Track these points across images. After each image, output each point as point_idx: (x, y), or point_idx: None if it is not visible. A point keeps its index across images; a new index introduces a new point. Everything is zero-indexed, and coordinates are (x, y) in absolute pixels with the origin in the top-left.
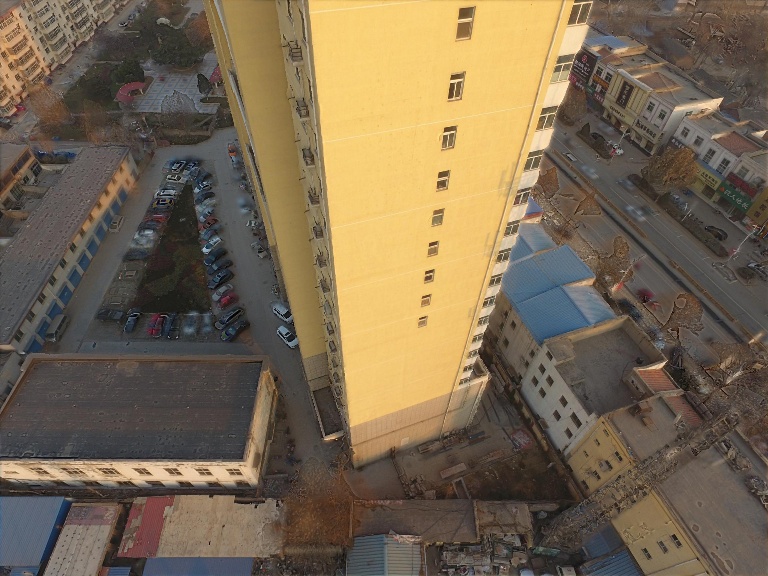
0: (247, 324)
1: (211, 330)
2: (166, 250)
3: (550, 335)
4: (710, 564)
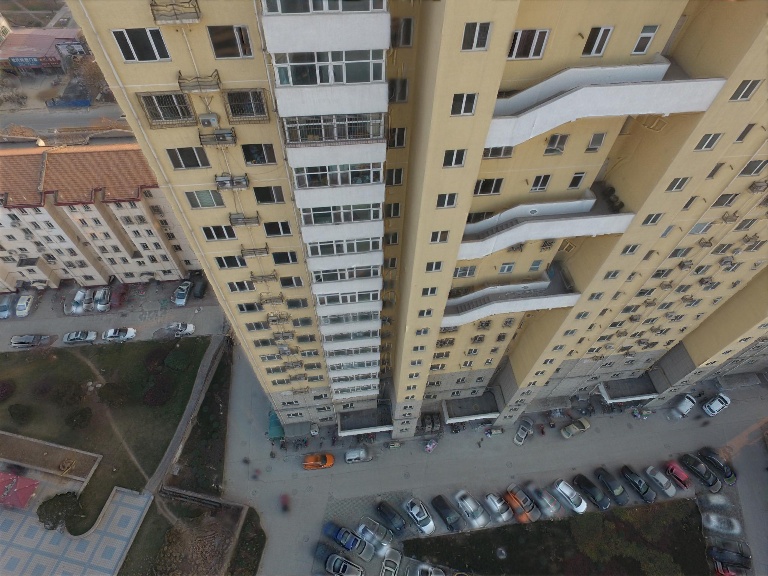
0: (705, 451)
1: (723, 498)
2: (586, 575)
3: None
4: None
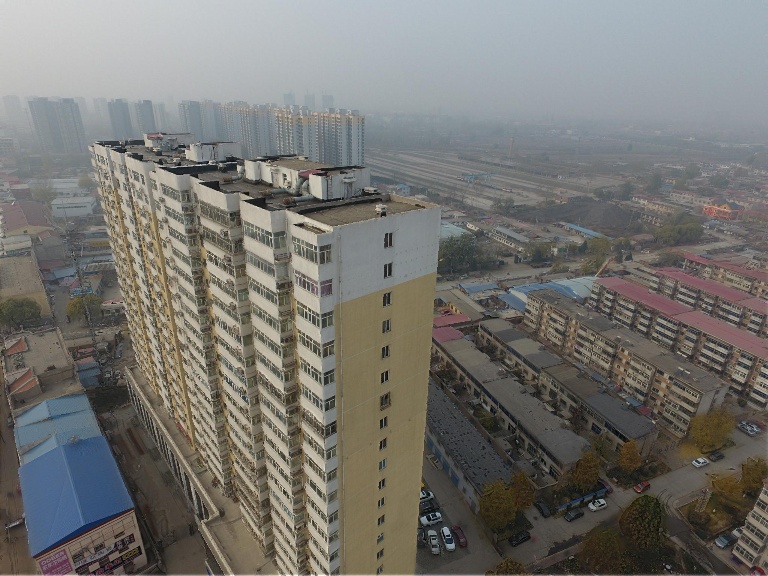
0: None
1: None
2: None
3: (76, 397)
4: (63, 340)
